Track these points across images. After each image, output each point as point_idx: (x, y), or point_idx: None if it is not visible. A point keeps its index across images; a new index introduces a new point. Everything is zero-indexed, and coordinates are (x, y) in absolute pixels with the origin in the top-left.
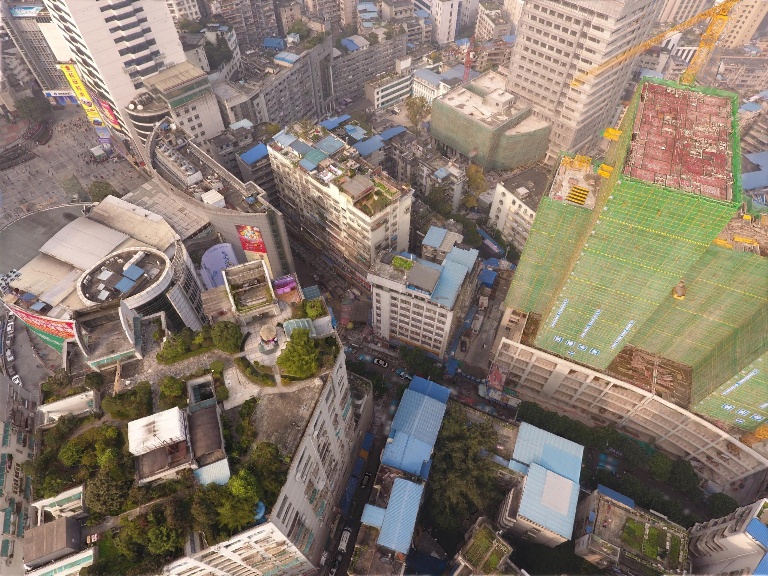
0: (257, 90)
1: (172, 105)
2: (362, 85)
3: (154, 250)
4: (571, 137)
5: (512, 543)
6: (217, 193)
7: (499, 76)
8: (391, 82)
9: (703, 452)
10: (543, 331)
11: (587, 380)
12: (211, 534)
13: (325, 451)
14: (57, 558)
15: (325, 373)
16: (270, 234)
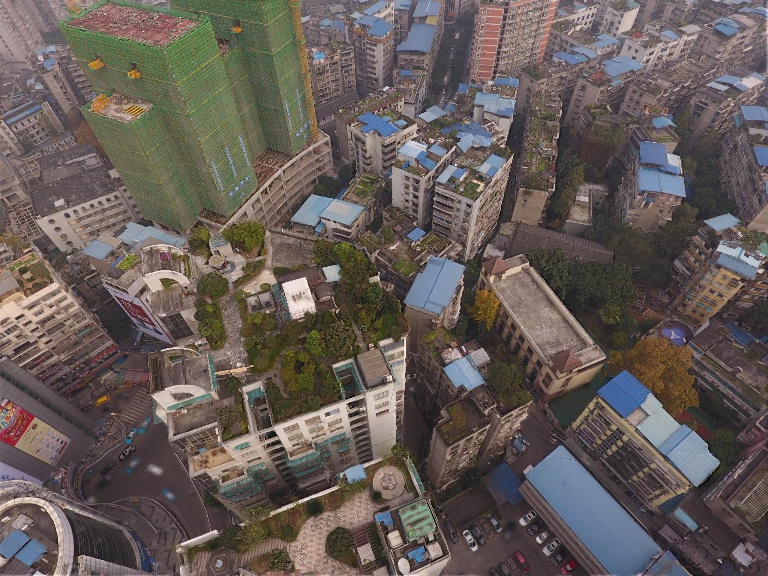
0: None
1: None
2: None
3: None
4: (3, 166)
5: None
6: None
7: None
8: None
9: (316, 169)
10: (223, 200)
11: (261, 202)
12: None
13: None
14: None
15: None
16: (19, 391)
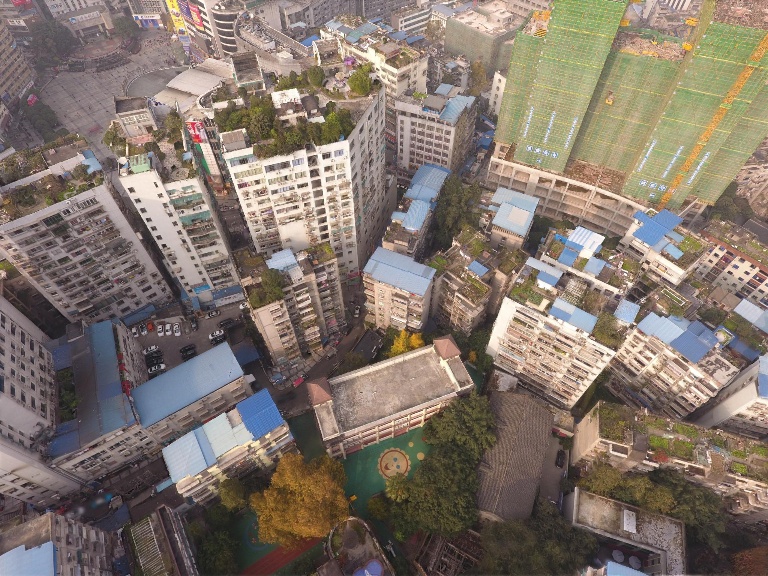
0: (308, 3)
1: (246, 7)
2: (388, 19)
3: None
4: None
5: None
6: (288, 53)
7: (502, 3)
8: (413, 13)
9: None
10: (519, 143)
11: (551, 186)
12: (318, 140)
13: (371, 159)
14: (238, 149)
15: (374, 95)
16: None
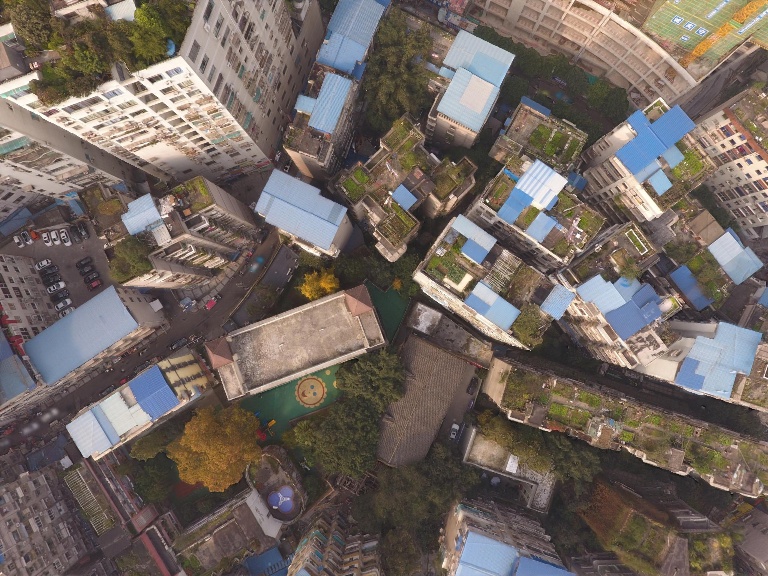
0: None
1: None
2: None
3: None
4: None
5: (440, 151)
6: None
7: None
8: None
9: (643, 80)
10: None
11: None
12: (130, 61)
13: (248, 28)
14: (10, 78)
15: None
16: None
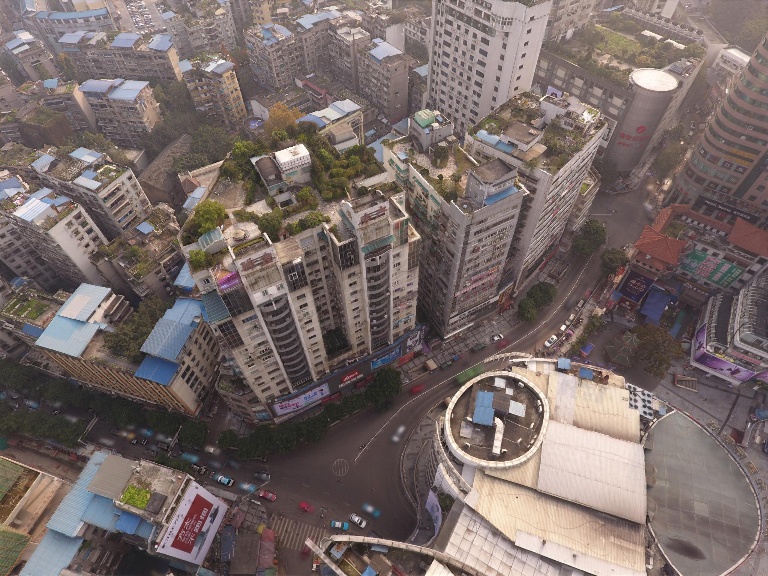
0: None
1: None
2: None
3: (484, 462)
4: None
5: None
6: None
7: None
8: None
9: None
10: (1, 459)
11: None
12: None
13: None
14: None
15: None
16: None
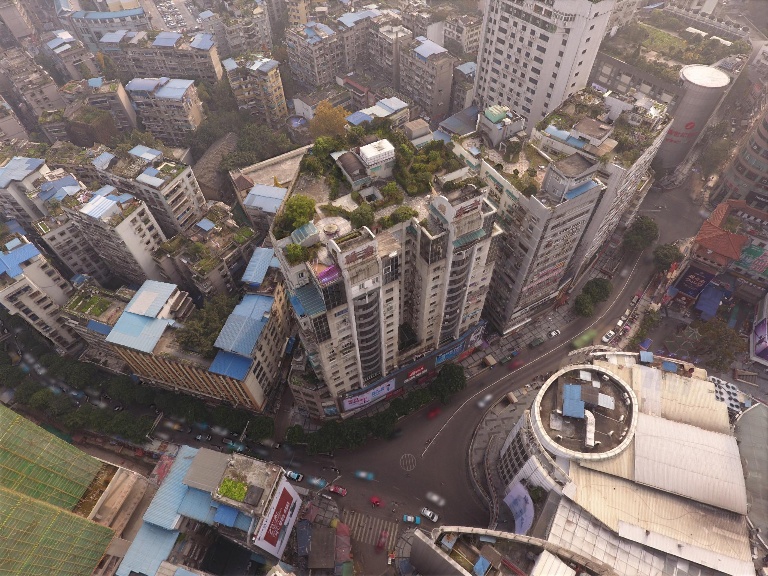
0: None
1: None
2: None
3: (579, 454)
4: None
5: None
6: None
7: None
8: None
9: None
10: None
11: None
12: None
13: None
14: None
15: None
16: None
